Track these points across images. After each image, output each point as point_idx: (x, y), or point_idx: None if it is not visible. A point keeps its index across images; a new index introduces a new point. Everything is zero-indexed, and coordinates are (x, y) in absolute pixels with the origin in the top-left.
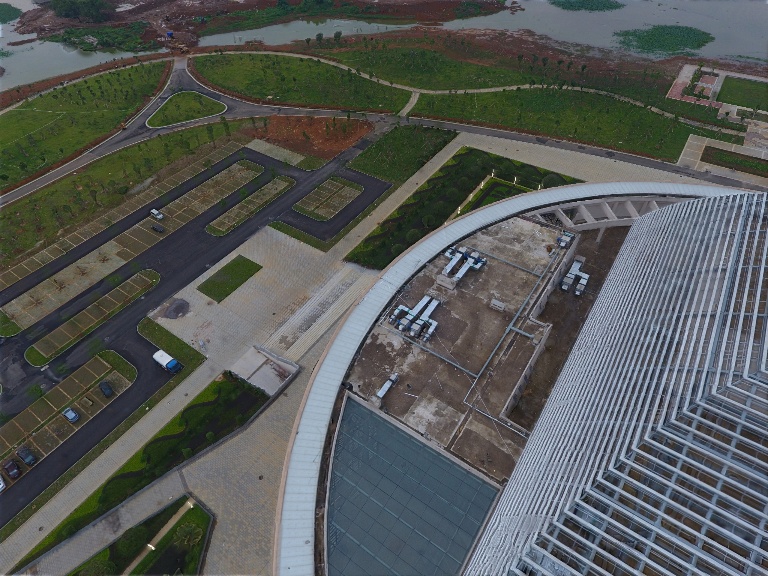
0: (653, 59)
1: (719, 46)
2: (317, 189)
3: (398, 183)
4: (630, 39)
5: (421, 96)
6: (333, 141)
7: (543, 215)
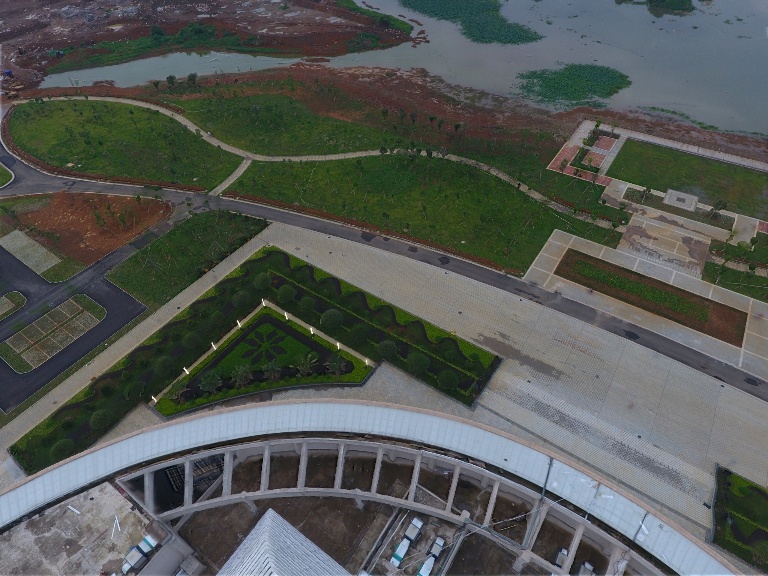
0: (551, 111)
1: (633, 94)
2: (46, 315)
3: (155, 306)
4: (534, 83)
5: (251, 165)
6: (107, 235)
7: (169, 467)
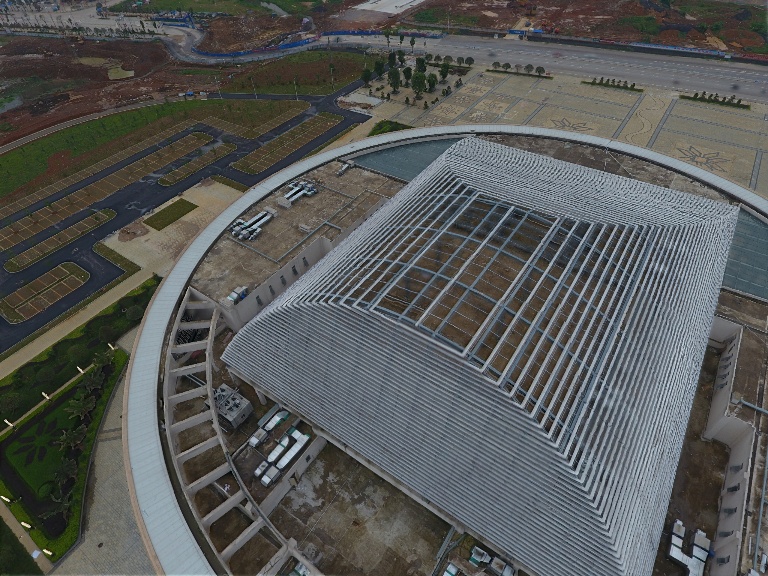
0: None
1: None
2: None
3: None
4: None
5: None
6: None
7: None
